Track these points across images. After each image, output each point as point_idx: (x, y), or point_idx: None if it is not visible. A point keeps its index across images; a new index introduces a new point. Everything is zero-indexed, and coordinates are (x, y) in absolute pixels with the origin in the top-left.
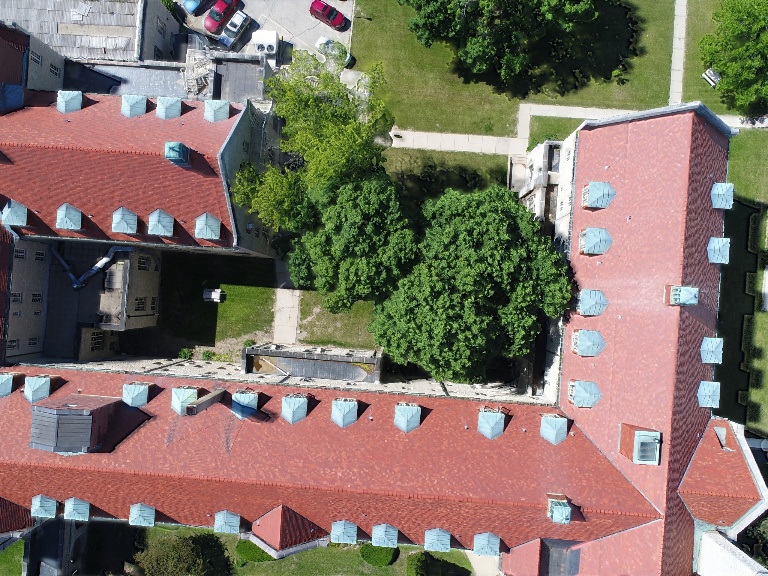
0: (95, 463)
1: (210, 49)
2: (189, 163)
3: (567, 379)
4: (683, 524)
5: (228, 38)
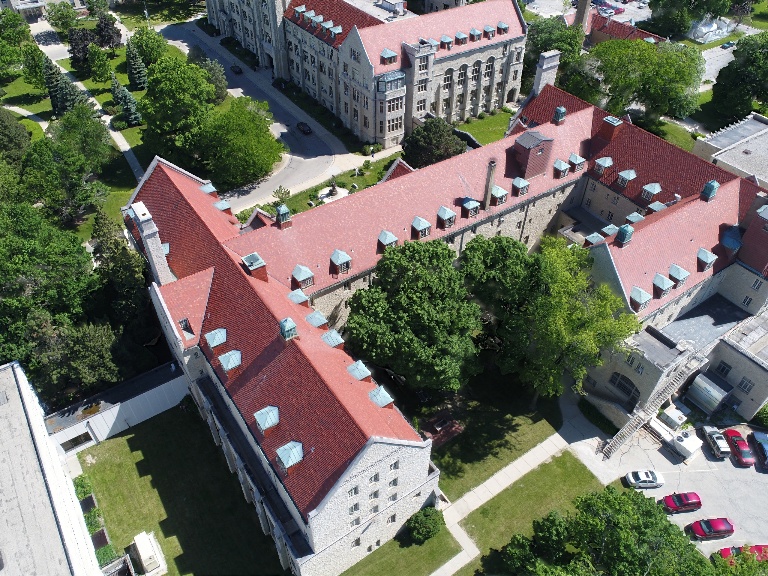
0: (507, 141)
1: (712, 421)
2: (615, 240)
3: (311, 309)
4: (195, 267)
5: (712, 430)
